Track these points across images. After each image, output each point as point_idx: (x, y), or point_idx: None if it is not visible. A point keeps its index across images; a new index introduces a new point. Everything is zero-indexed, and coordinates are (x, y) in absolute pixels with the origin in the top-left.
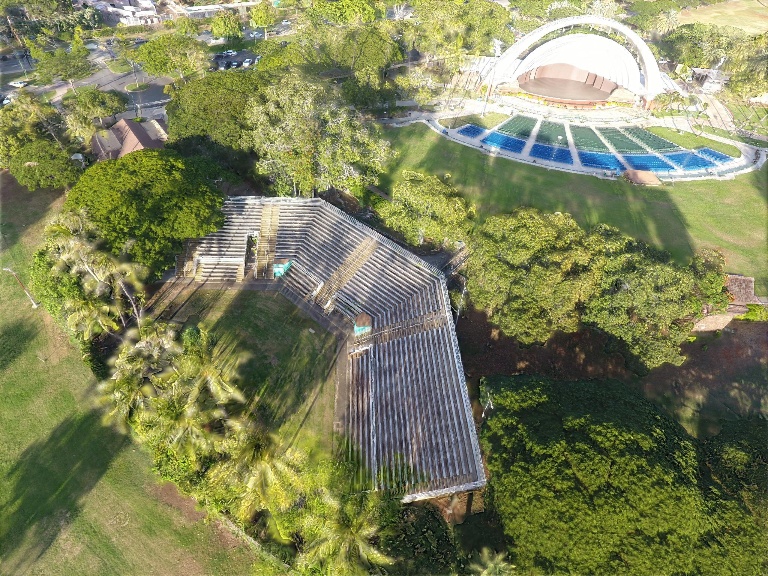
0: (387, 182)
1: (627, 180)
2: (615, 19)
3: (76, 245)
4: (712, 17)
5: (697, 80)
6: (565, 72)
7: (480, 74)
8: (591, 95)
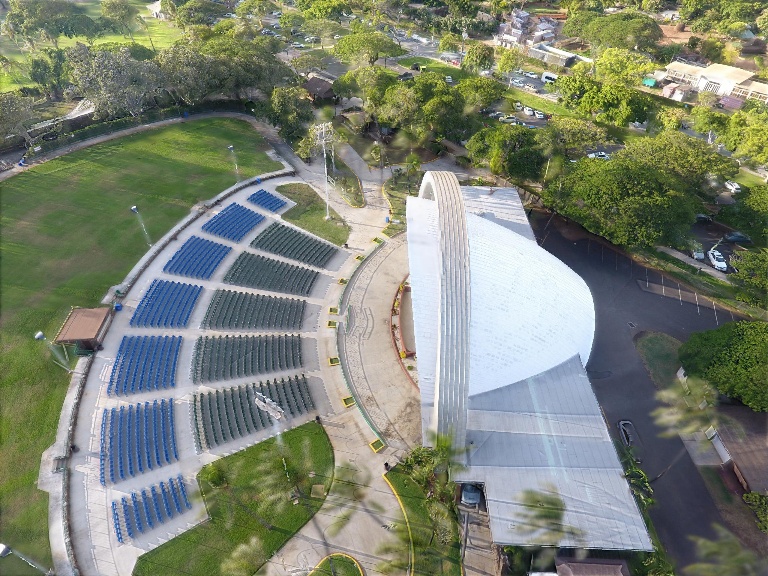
0: (133, 140)
1: None
2: None
3: (10, 34)
4: None
5: None
6: None
7: None
8: None
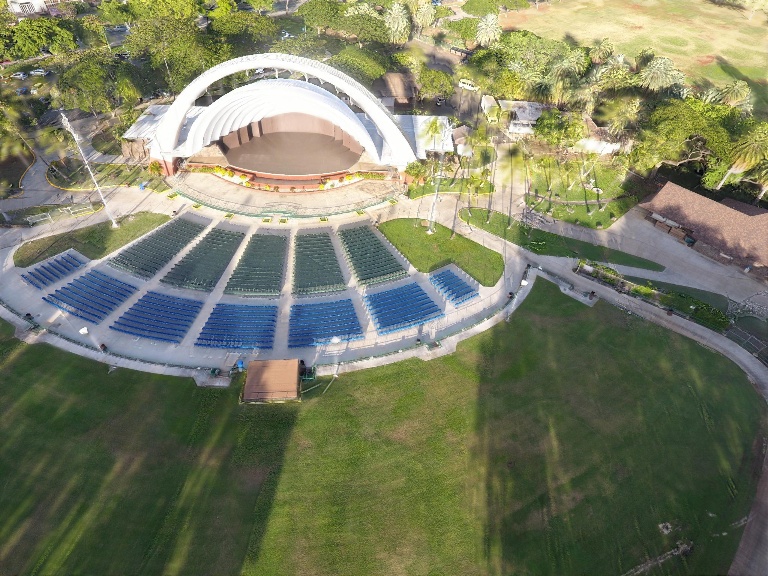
0: None
1: (242, 387)
2: (443, 23)
3: None
4: (574, 11)
5: (508, 117)
6: (306, 123)
7: (146, 144)
8: (329, 162)
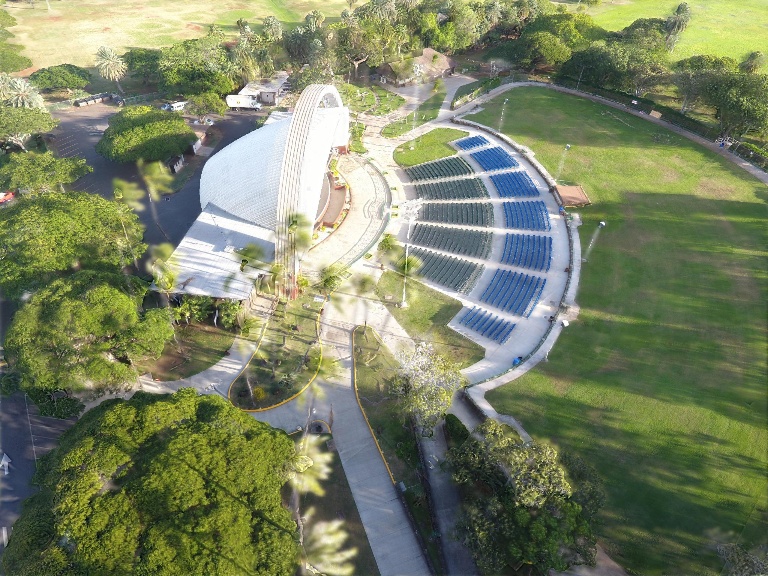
0: None
1: (579, 206)
2: None
3: None
4: (33, 40)
5: None
6: None
7: (278, 274)
8: None
